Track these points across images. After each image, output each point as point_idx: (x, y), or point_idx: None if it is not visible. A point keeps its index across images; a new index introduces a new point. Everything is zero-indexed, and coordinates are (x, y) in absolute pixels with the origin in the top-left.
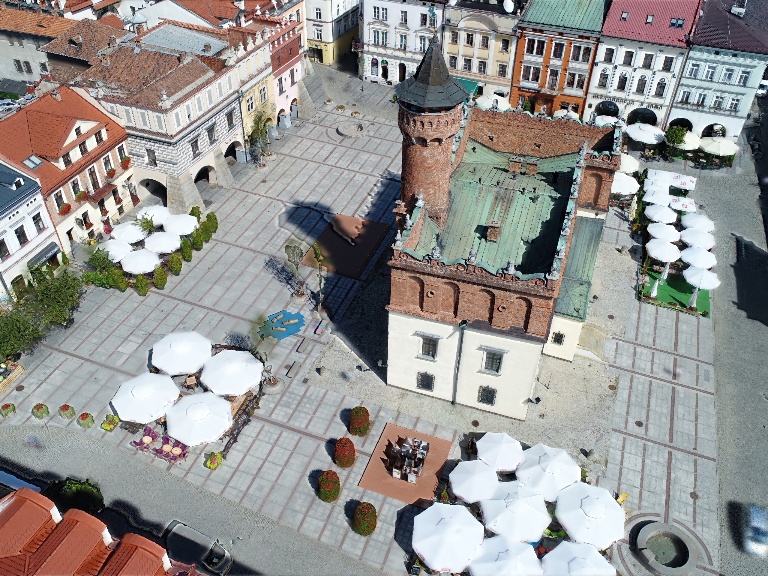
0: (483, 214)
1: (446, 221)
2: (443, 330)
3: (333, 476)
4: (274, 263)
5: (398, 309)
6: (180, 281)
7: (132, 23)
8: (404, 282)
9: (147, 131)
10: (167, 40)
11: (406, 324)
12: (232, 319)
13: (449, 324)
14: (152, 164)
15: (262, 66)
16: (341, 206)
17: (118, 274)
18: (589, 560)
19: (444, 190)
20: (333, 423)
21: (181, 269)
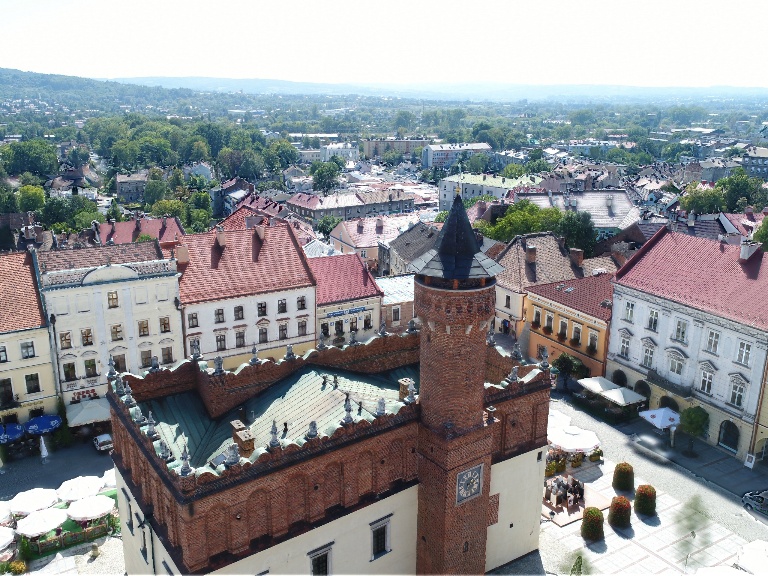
0: (392, 406)
1: None
2: None
3: (644, 486)
4: None
5: None
6: None
7: None
8: None
9: None
10: None
11: None
12: None
13: None
14: None
15: None
16: None
17: None
18: None
19: None
20: (618, 548)
21: None
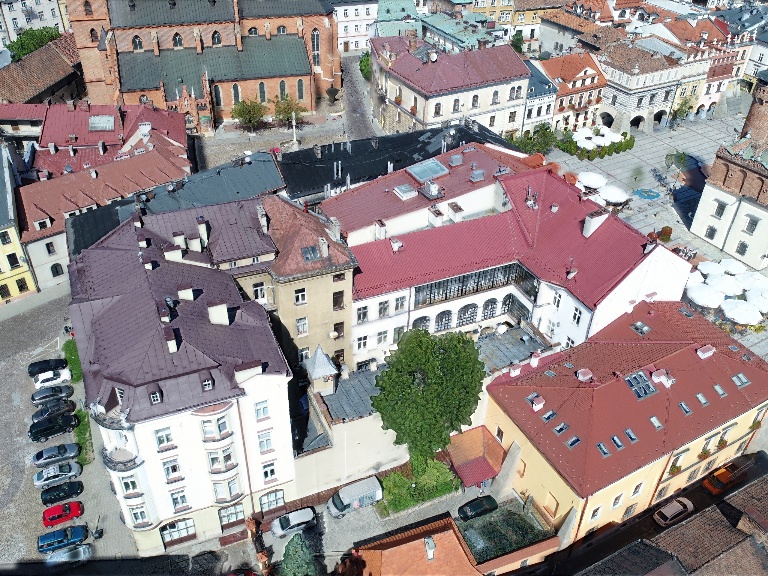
0: None
1: (762, 155)
2: (731, 199)
3: None
4: (656, 171)
5: (711, 182)
6: (602, 161)
7: (634, 32)
8: (720, 166)
9: (619, 84)
10: (650, 45)
11: (712, 192)
12: (621, 183)
13: (735, 196)
14: (613, 104)
15: (701, 72)
16: (712, 162)
17: (574, 144)
18: (750, 306)
19: (766, 134)
20: None
21: (604, 157)
